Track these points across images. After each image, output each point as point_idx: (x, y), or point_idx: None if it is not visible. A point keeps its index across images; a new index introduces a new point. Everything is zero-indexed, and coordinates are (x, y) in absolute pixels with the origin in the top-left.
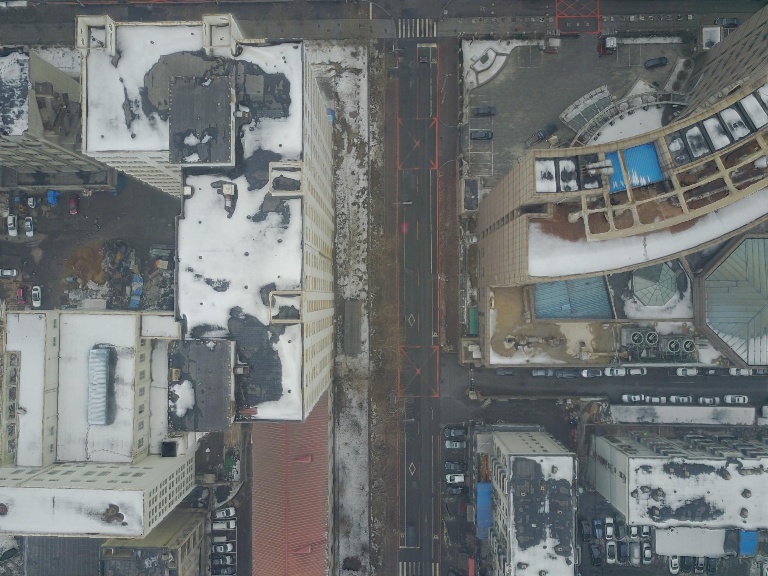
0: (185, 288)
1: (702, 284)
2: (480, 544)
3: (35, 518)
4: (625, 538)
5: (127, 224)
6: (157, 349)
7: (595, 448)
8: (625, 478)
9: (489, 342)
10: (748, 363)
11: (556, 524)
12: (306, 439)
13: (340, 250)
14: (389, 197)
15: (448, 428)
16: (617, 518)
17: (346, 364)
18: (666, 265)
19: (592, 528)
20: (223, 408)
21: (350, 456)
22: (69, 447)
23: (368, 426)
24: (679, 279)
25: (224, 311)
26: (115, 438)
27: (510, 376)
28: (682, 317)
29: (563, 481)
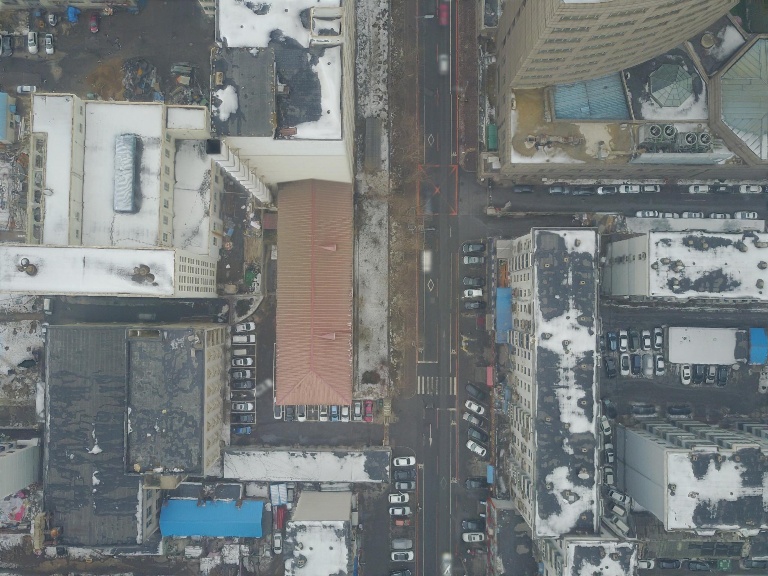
0: (226, 11)
1: (718, 81)
2: (498, 351)
3: (65, 278)
4: (638, 351)
5: (148, 43)
6: (181, 151)
7: (611, 254)
8: (645, 255)
9: (510, 141)
10: (761, 158)
11: (579, 295)
12: (331, 228)
13: (361, 70)
14: (409, 20)
15: (466, 244)
16: (631, 330)
17: (366, 181)
18: (682, 68)
19: (607, 341)
20: (266, 113)
21: (369, 273)
22: (94, 235)
23: (387, 243)
24: (694, 82)
25: (264, 34)
26: (140, 227)
27: (527, 194)
28: (697, 118)
29: (586, 254)
